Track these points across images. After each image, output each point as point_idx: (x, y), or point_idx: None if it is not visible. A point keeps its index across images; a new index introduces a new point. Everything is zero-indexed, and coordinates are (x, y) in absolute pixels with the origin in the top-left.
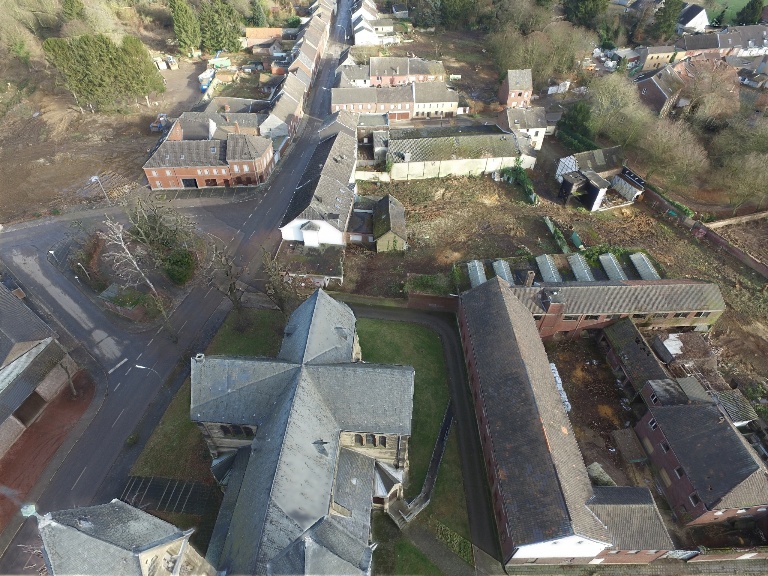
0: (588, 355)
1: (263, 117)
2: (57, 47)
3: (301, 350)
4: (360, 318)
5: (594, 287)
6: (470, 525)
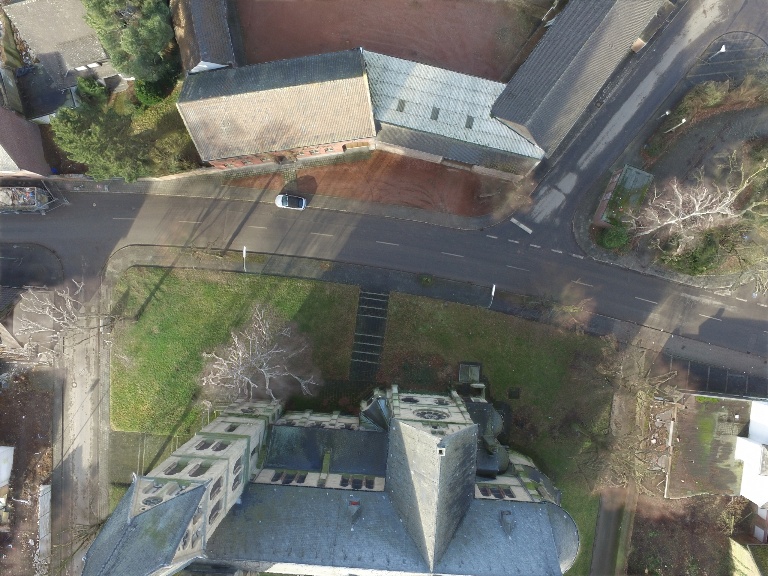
0: None
1: None
2: None
3: (459, 563)
4: (596, 516)
5: None
6: None
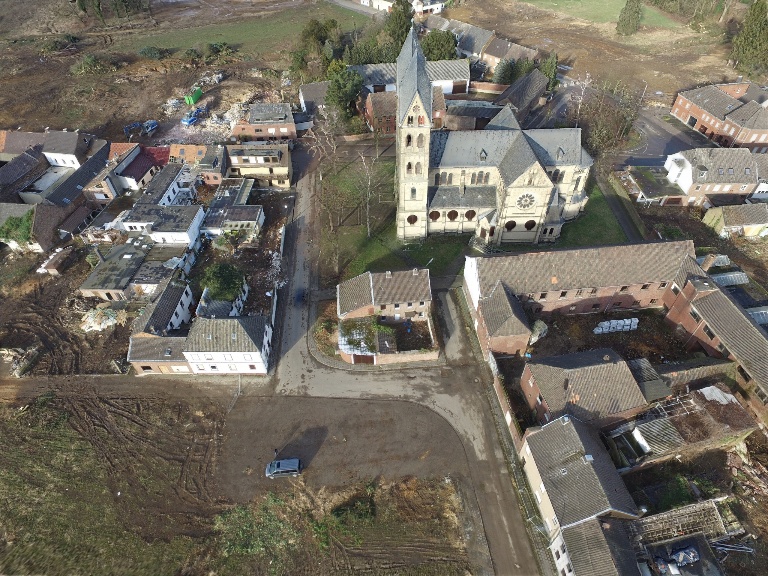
0: (673, 358)
1: None
2: (760, 9)
3: None
4: (616, 219)
5: (743, 316)
6: None
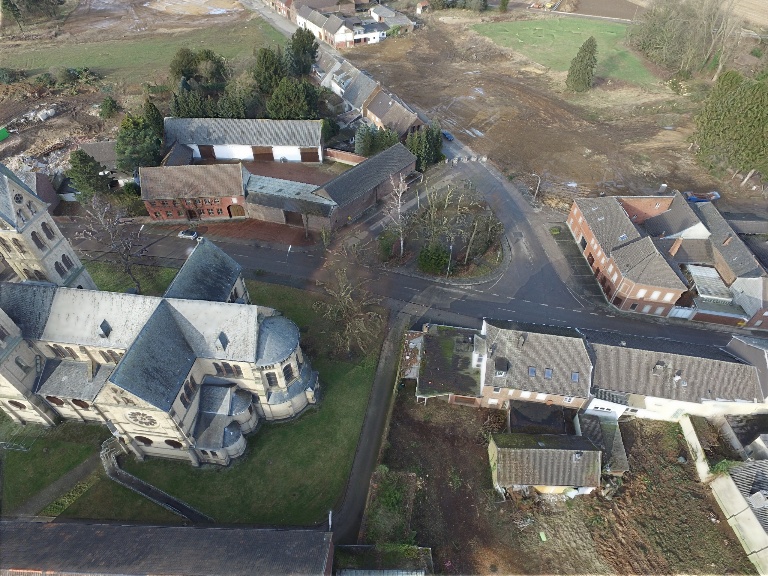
0: None
1: (759, 275)
2: (730, 81)
3: None
4: (361, 424)
5: None
6: (73, 518)
